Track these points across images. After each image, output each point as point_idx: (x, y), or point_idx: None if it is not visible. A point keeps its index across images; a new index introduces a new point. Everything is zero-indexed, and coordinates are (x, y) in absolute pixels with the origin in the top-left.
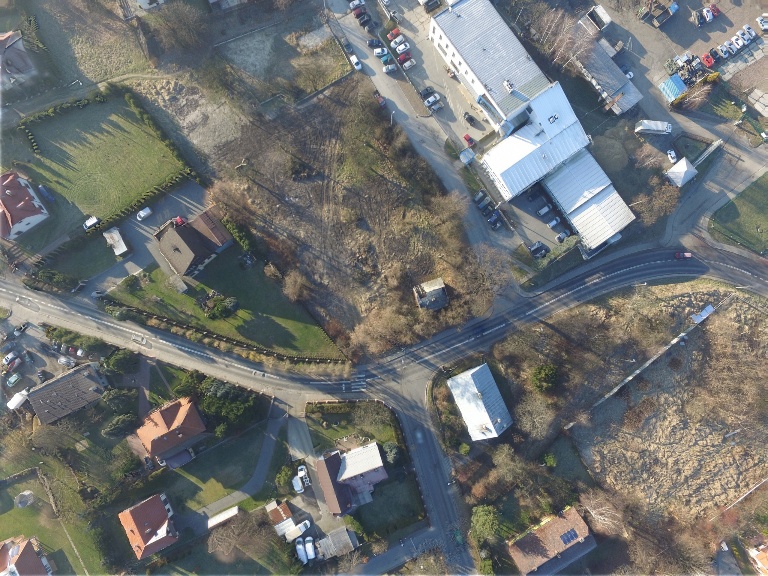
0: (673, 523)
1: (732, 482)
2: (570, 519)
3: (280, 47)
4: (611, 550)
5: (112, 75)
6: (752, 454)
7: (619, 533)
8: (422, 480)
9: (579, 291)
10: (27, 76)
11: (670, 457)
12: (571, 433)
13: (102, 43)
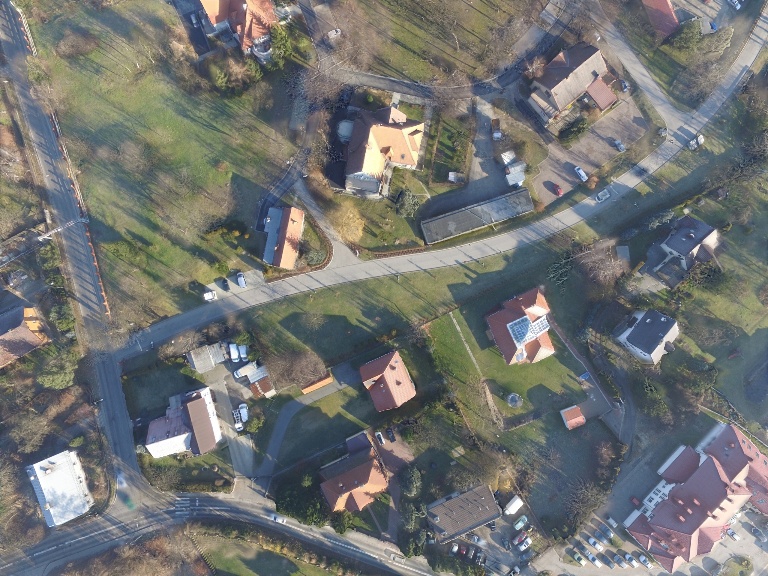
0: None
1: None
2: None
3: None
4: None
5: None
6: None
7: None
8: None
9: None
10: None
11: None
12: None
13: None
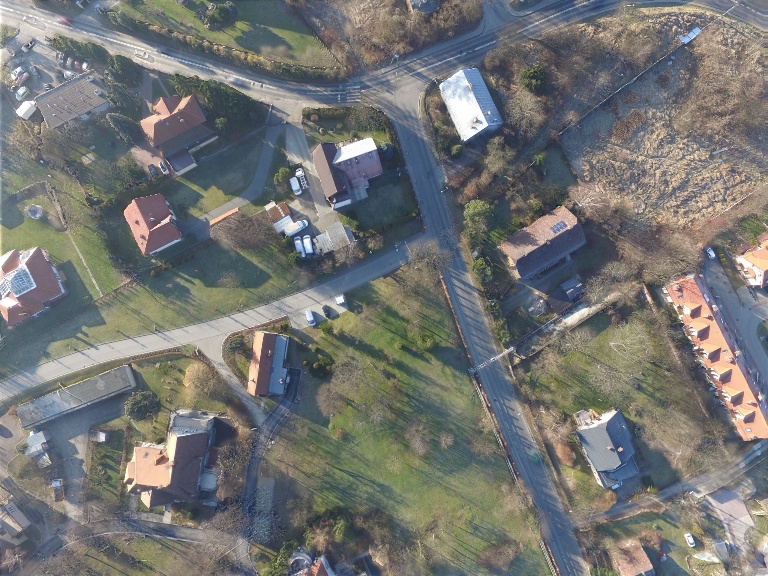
0: (661, 232)
1: (719, 196)
2: (560, 215)
3: None
4: (600, 257)
5: None
6: (739, 171)
7: (606, 208)
8: (416, 187)
9: (568, 12)
10: None
11: (658, 169)
12: (561, 143)
13: None
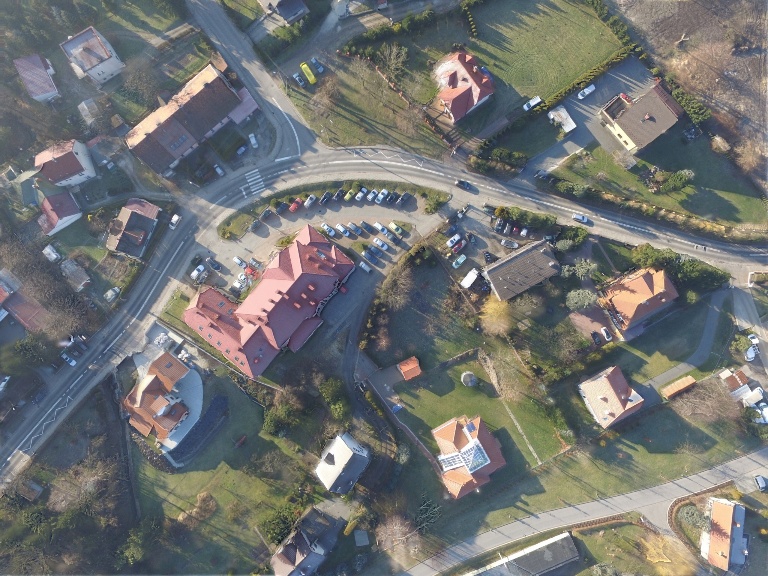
0: None
1: None
2: None
3: None
4: None
5: None
6: None
7: None
8: None
9: None
10: None
11: None
12: None
13: None
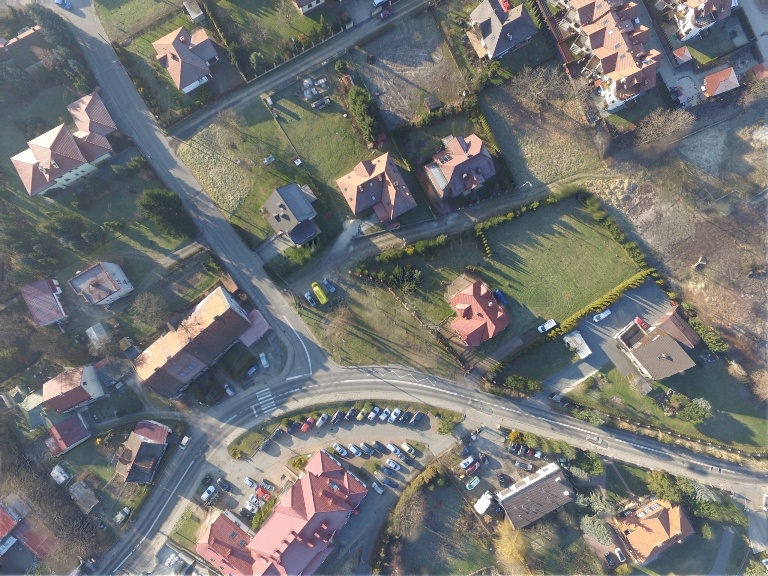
0: None
1: None
2: None
3: (733, 142)
4: None
5: (562, 175)
6: None
7: None
8: None
9: None
10: (487, 181)
11: None
12: None
13: (552, 143)
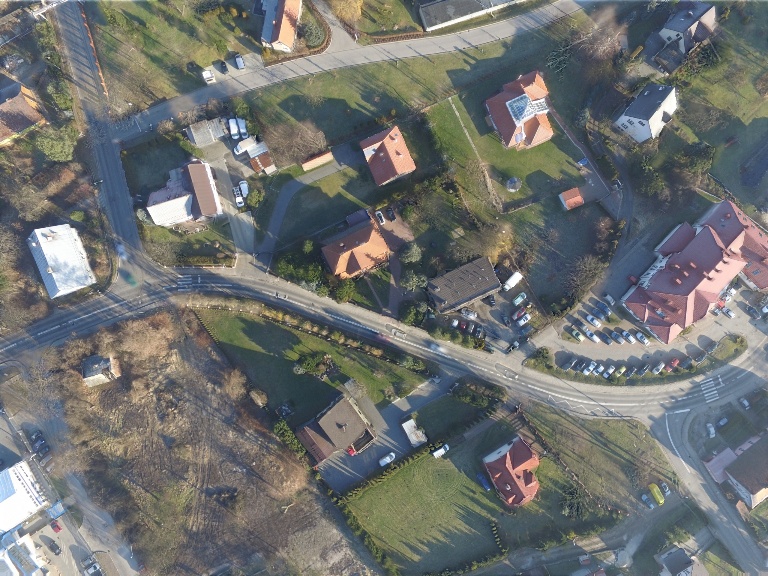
0: None
1: None
2: None
3: None
4: None
5: None
6: None
7: None
8: None
9: None
10: None
11: None
12: None
13: None
